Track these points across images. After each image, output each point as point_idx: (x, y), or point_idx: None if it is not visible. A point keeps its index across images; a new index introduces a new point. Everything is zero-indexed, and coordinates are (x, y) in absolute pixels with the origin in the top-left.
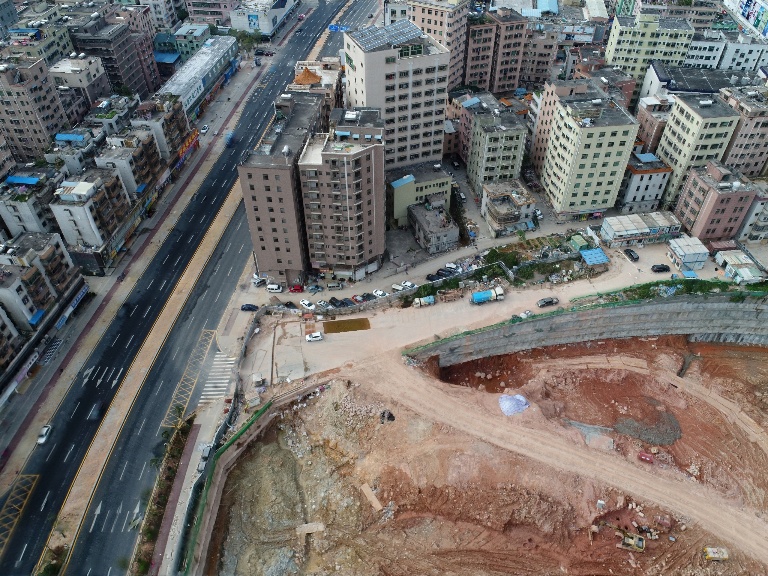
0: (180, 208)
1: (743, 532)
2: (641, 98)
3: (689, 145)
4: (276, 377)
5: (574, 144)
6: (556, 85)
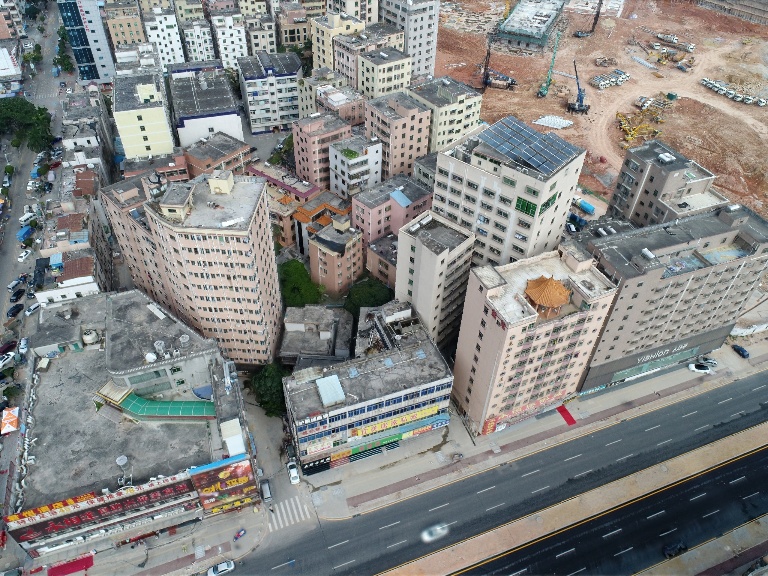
0: (715, 548)
1: (601, 142)
2: (336, 101)
3: (408, 82)
4: (766, 295)
5: (478, 112)
6: (413, 108)
